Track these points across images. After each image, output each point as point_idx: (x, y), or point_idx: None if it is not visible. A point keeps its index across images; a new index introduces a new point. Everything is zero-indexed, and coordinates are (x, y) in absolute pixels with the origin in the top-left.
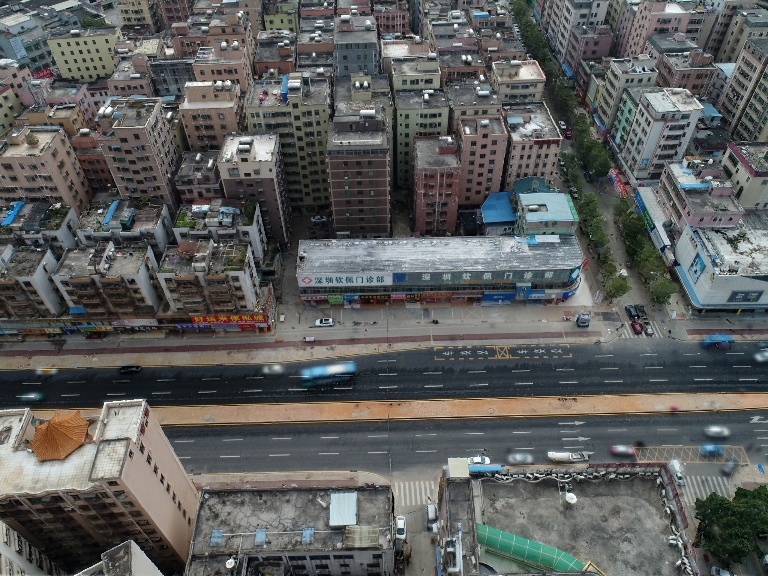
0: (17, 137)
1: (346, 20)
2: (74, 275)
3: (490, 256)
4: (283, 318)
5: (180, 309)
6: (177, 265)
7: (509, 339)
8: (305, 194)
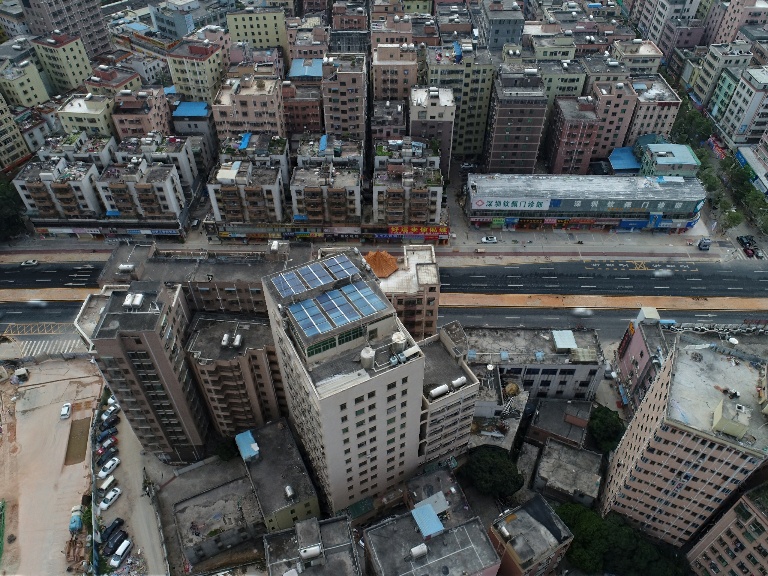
0: (249, 81)
1: (498, 1)
2: (307, 186)
3: (629, 190)
4: (455, 235)
5: (380, 220)
6: (386, 182)
7: (644, 257)
8: (458, 144)
